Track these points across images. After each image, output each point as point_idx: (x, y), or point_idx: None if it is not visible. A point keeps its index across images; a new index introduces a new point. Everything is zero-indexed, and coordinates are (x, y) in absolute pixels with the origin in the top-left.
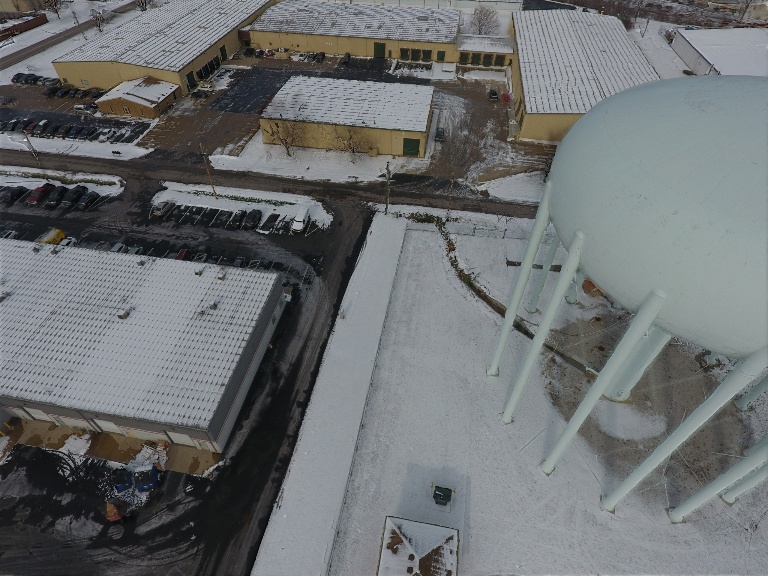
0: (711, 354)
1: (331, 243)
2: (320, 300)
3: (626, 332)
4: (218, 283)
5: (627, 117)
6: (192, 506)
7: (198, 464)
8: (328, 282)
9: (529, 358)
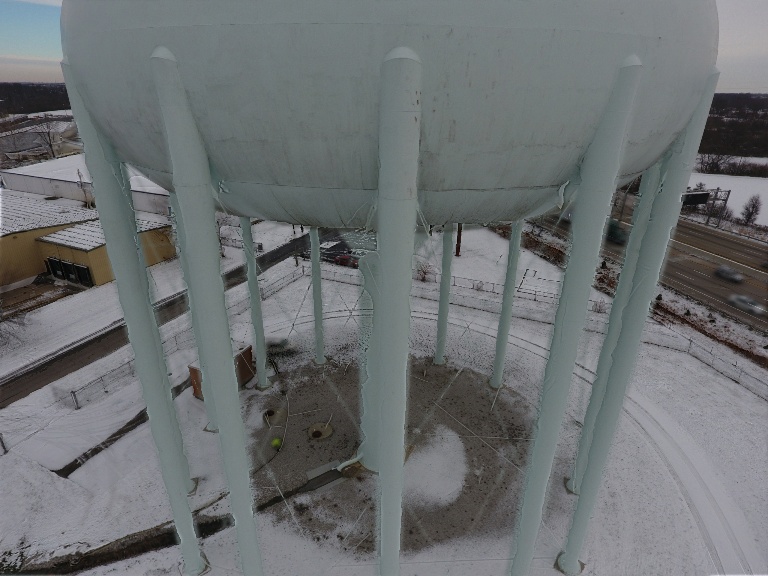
0: None
1: None
2: None
3: (588, 219)
4: None
5: None
6: None
7: None
8: None
9: (394, 504)
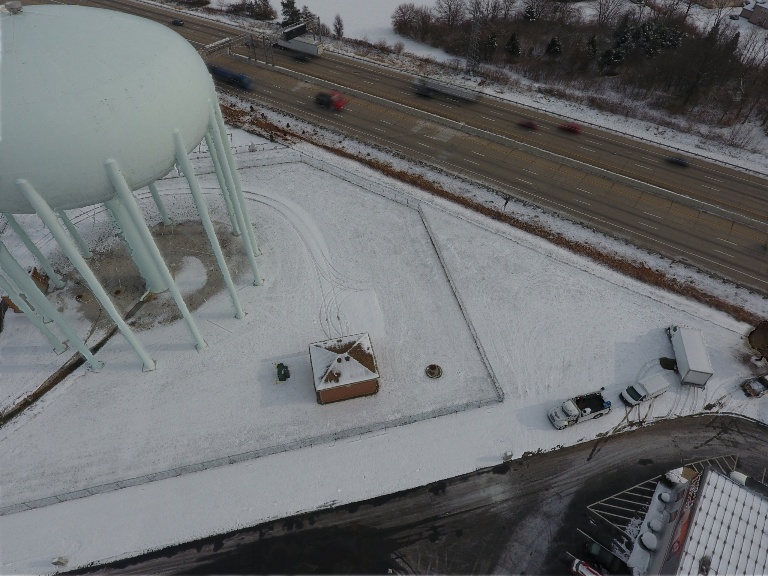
0: None
1: None
2: None
3: (187, 174)
4: None
5: None
6: None
7: None
8: None
9: (172, 283)
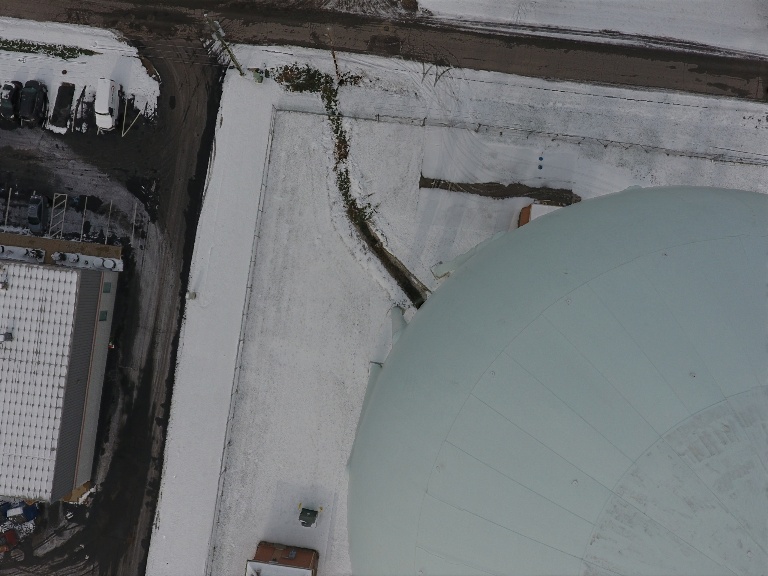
0: None
1: (163, 150)
2: (161, 267)
3: None
4: (1, 294)
5: (461, 527)
6: (77, 531)
7: (70, 492)
8: (168, 233)
9: None
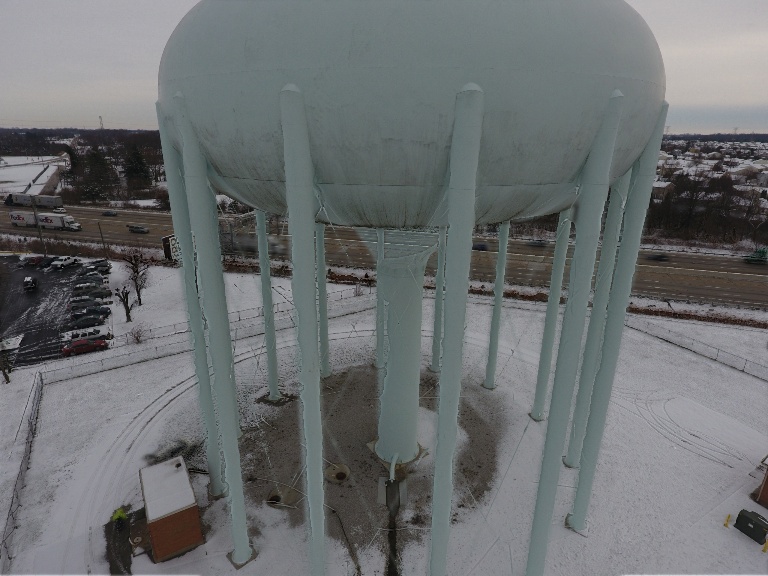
0: (276, 389)
1: None
2: None
3: None
4: None
5: None
6: None
7: None
8: None
9: None
